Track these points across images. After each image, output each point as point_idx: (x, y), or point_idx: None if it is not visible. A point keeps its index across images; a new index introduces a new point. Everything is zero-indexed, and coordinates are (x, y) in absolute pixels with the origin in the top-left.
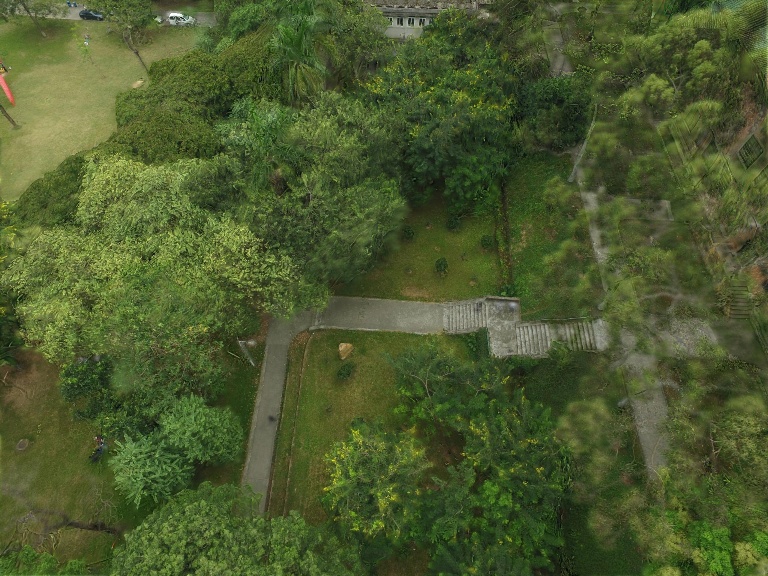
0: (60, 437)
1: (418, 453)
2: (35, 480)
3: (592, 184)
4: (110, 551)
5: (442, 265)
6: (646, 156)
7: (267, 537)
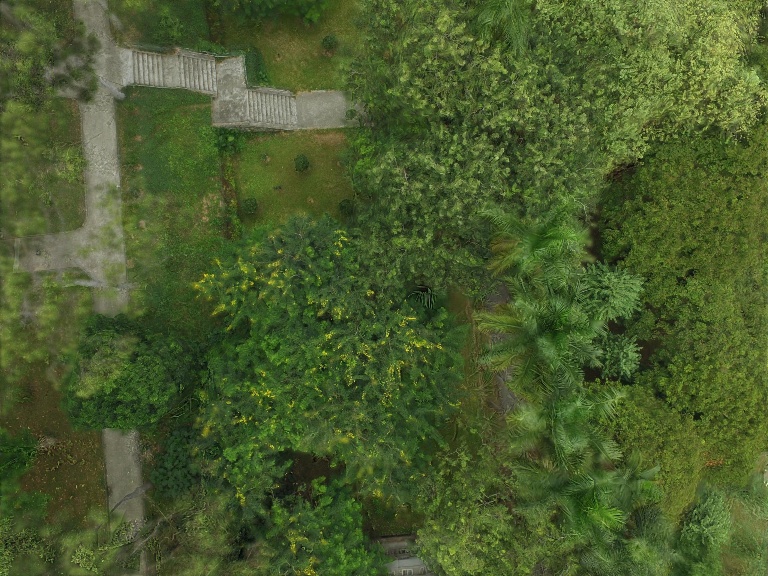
0: None
1: None
2: None
3: (109, 287)
4: None
5: (300, 157)
6: (27, 355)
7: None
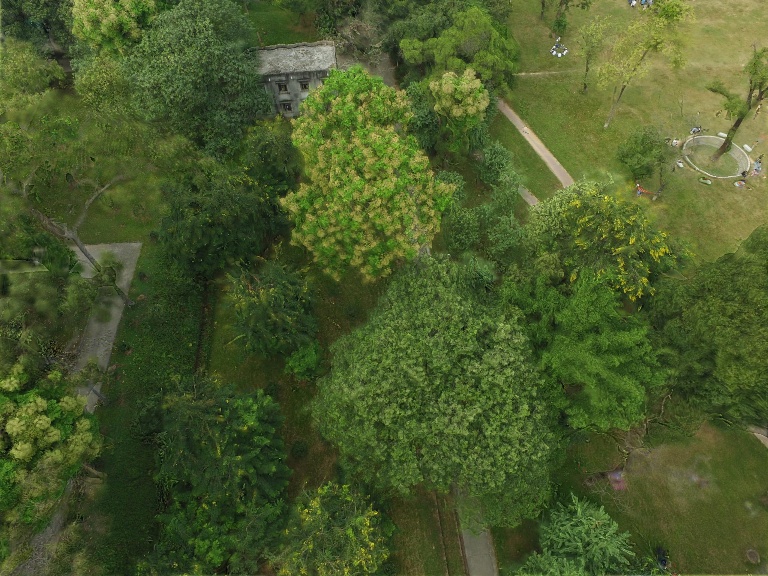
0: (721, 572)
1: (284, 573)
2: (705, 519)
3: None
4: (580, 460)
5: None
6: None
7: (423, 465)
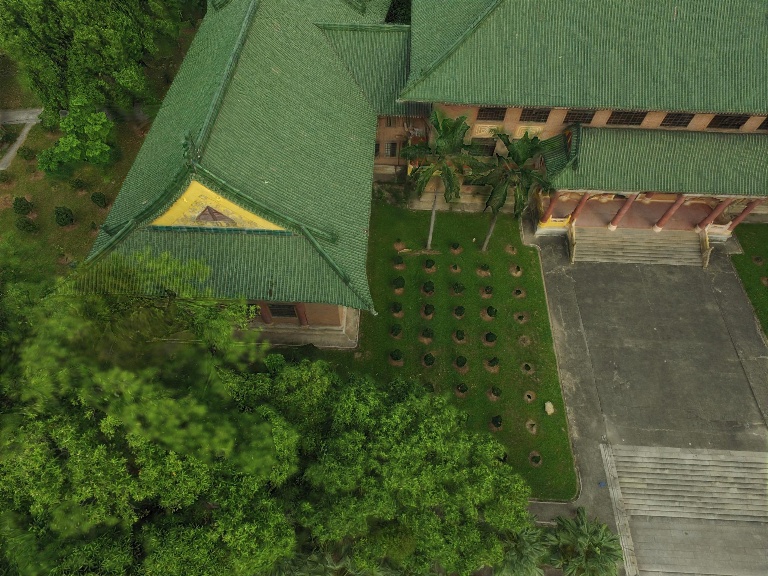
0: None
1: None
2: None
3: None
4: None
5: None
6: None
7: None
